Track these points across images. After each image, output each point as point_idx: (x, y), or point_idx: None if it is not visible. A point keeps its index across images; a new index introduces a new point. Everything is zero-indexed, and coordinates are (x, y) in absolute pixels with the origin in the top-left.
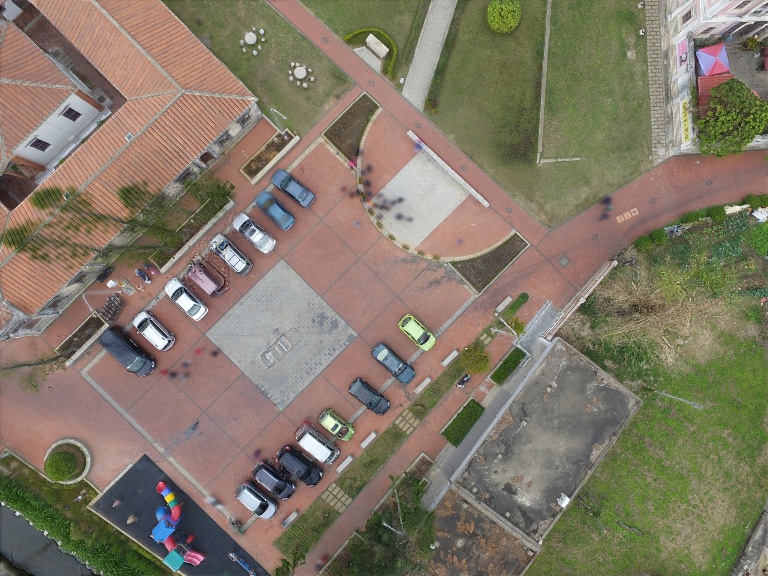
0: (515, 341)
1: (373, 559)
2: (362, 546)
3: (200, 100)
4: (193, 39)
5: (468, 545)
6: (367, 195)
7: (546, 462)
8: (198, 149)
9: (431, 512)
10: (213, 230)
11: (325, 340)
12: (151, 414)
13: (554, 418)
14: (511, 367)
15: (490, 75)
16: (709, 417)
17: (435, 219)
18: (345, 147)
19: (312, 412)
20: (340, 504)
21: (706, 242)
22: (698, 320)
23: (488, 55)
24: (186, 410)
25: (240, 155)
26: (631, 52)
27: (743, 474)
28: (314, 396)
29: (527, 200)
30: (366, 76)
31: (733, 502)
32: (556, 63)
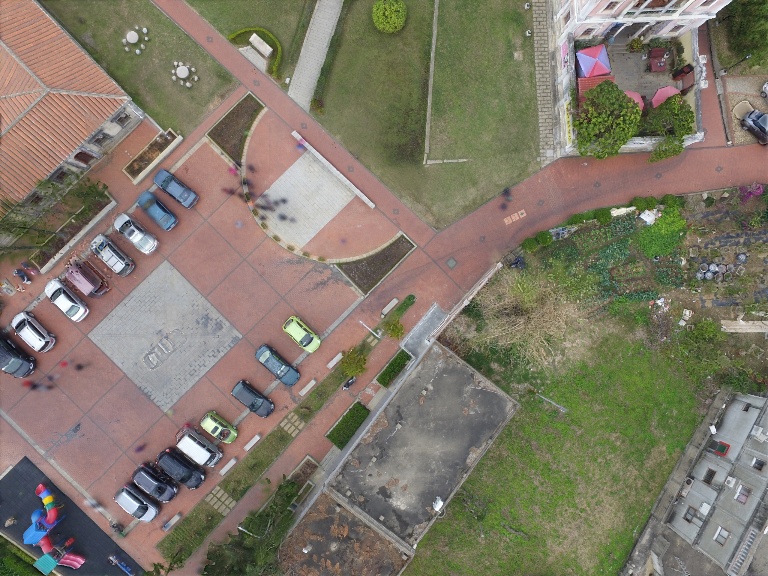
0: (401, 343)
1: (226, 563)
2: (220, 550)
3: (68, 99)
4: (64, 38)
5: (342, 549)
6: (252, 196)
7: (422, 465)
8: (69, 149)
9: (303, 516)
10: (95, 230)
11: (209, 342)
12: (32, 416)
13: (430, 421)
14: (396, 369)
15: (377, 75)
16: (597, 420)
17: (321, 220)
18: (229, 147)
19: (196, 414)
20: (224, 507)
21: (594, 244)
22: (586, 323)
23: (375, 55)
24: (67, 412)
25: (123, 155)
26: (518, 53)
27: (631, 478)
28: (198, 398)
29: (414, 201)
30: (251, 76)
31: (621, 506)
32: (443, 64)
